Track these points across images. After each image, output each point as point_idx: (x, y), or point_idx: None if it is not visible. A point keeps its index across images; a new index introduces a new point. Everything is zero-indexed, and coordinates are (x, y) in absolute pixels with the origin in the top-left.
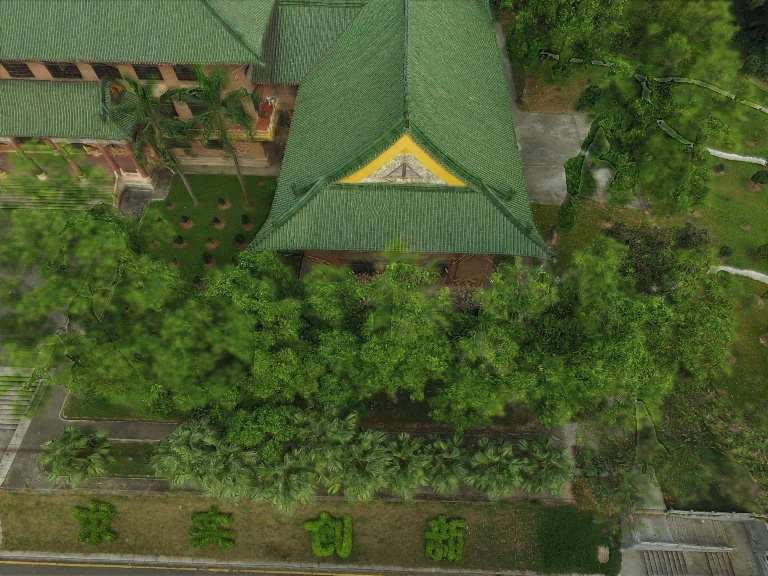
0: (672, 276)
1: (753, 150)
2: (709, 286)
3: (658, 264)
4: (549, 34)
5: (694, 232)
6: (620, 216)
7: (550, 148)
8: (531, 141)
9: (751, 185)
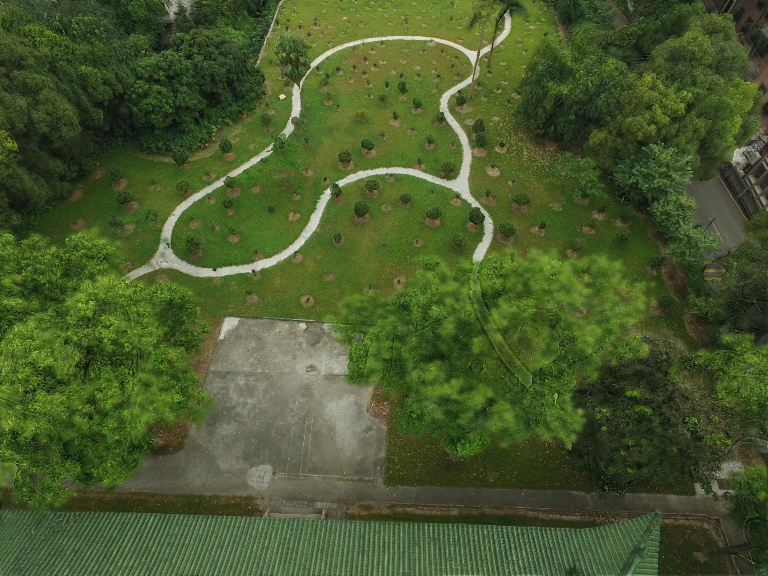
0: (761, 403)
1: (307, 198)
2: (751, 365)
3: (732, 409)
4: (130, 409)
5: (665, 352)
6: (405, 359)
7: (273, 420)
8: (254, 446)
9: (360, 218)
